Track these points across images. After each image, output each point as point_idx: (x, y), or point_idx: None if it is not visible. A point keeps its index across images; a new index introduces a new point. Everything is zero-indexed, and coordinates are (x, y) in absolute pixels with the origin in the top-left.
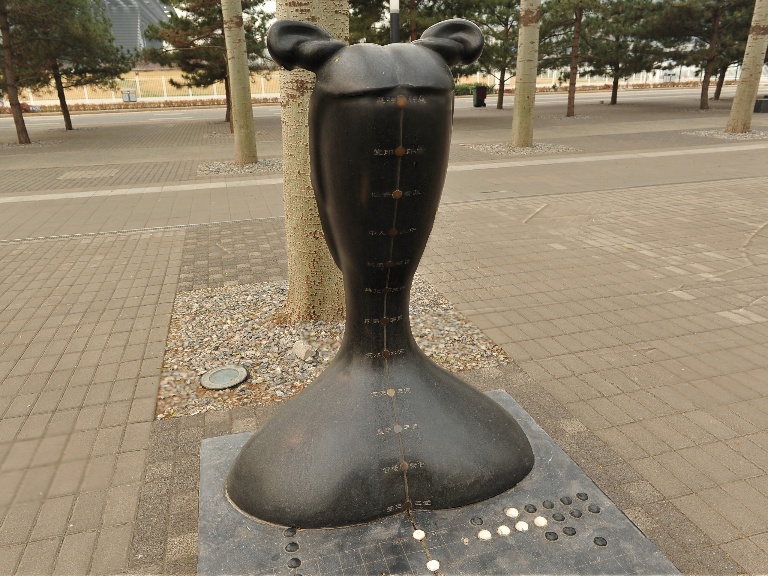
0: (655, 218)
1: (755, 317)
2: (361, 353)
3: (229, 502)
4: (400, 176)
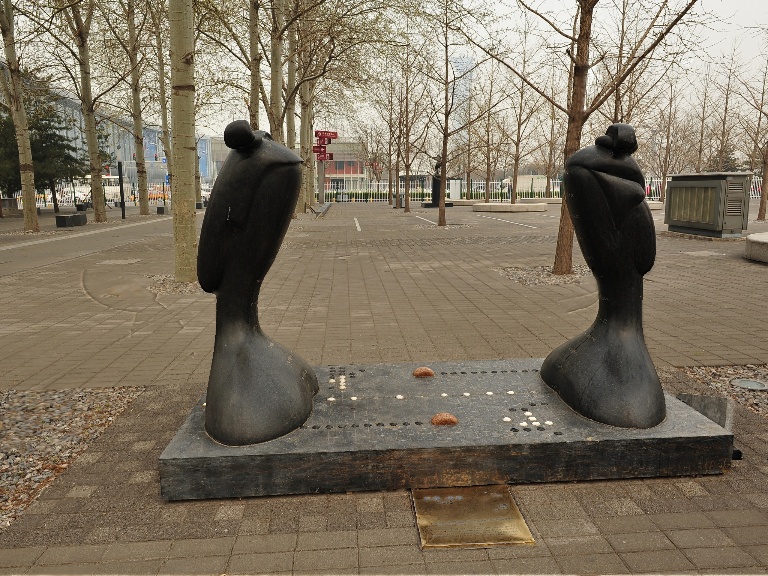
0: (5, 309)
1: (198, 328)
2: (251, 327)
3: (257, 445)
4: None
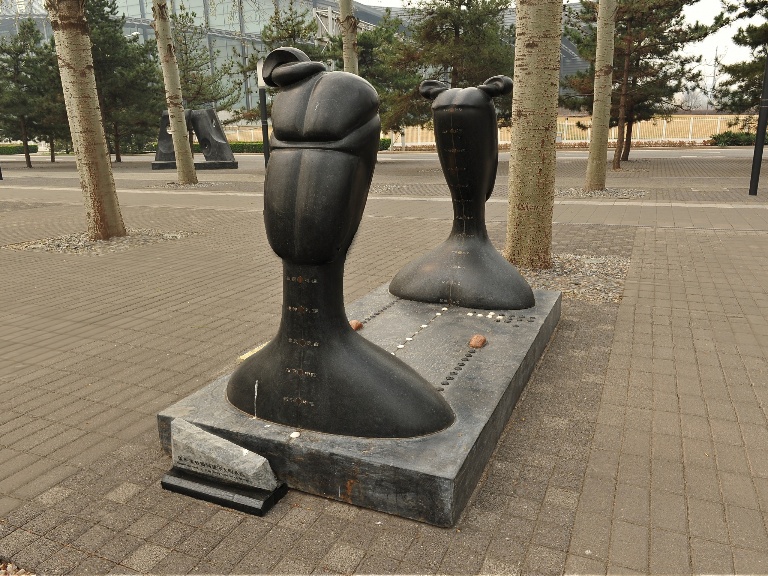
0: None
1: None
2: (454, 234)
3: (388, 290)
4: (454, 142)
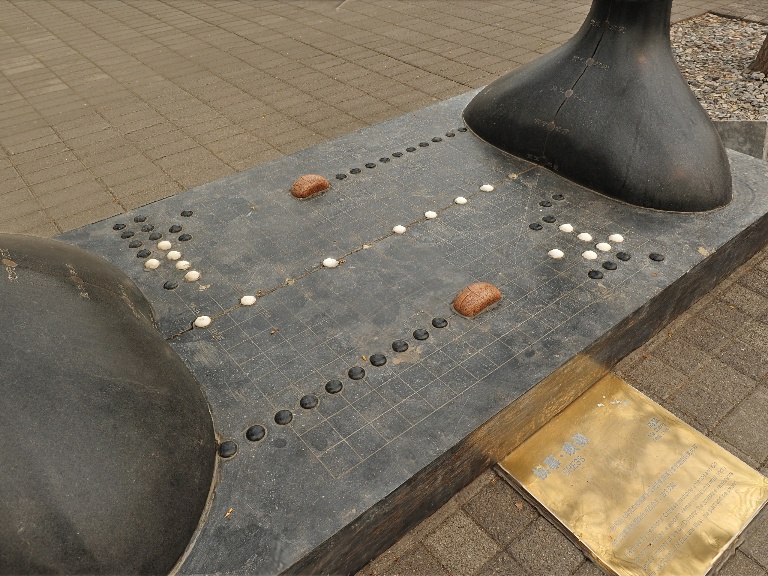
0: None
1: None
2: None
3: None
4: None
